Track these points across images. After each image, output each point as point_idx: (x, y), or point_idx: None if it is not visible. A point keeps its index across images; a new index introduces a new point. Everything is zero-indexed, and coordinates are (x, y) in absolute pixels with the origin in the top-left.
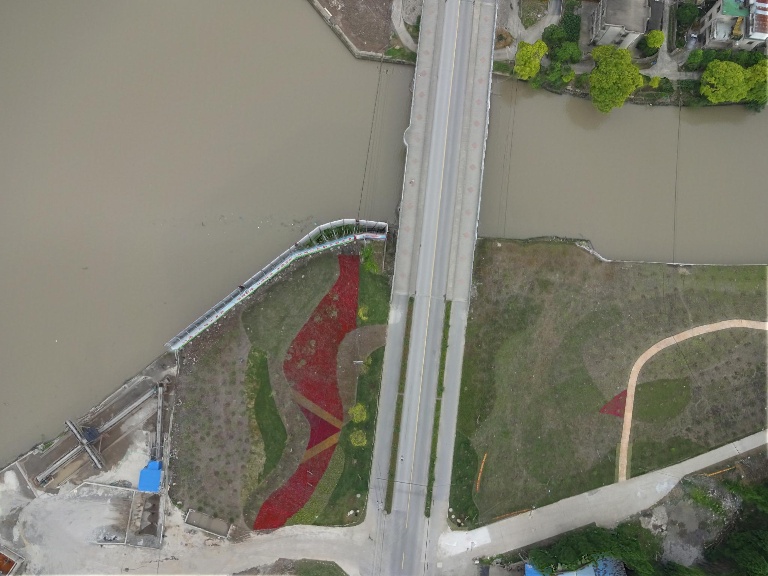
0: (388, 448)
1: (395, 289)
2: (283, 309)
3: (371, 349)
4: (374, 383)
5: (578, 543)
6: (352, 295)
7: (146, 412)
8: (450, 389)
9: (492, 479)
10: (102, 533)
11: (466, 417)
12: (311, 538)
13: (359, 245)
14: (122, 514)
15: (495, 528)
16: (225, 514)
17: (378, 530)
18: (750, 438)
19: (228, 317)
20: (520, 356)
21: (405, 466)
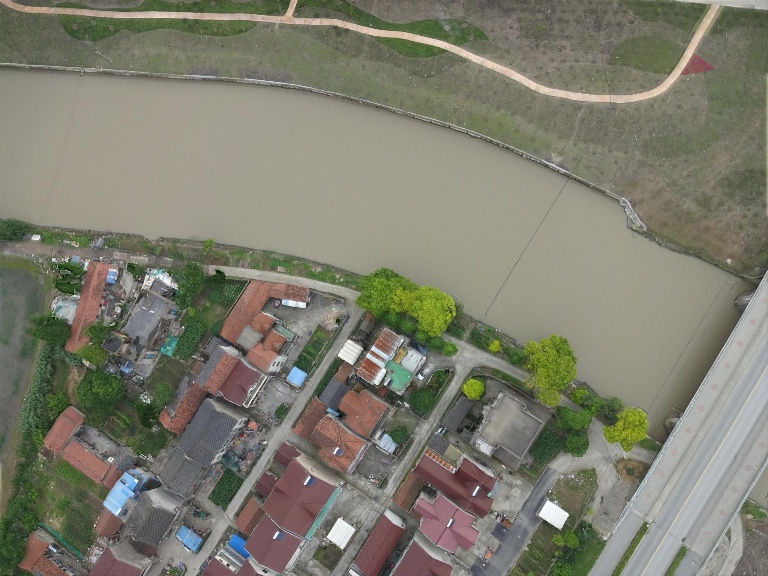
0: None
1: None
2: None
3: None
4: None
5: None
6: None
7: None
8: None
9: None
10: None
11: None
12: None
13: None
14: None
15: None
16: None
17: None
18: None
19: None
20: (764, 148)
21: None
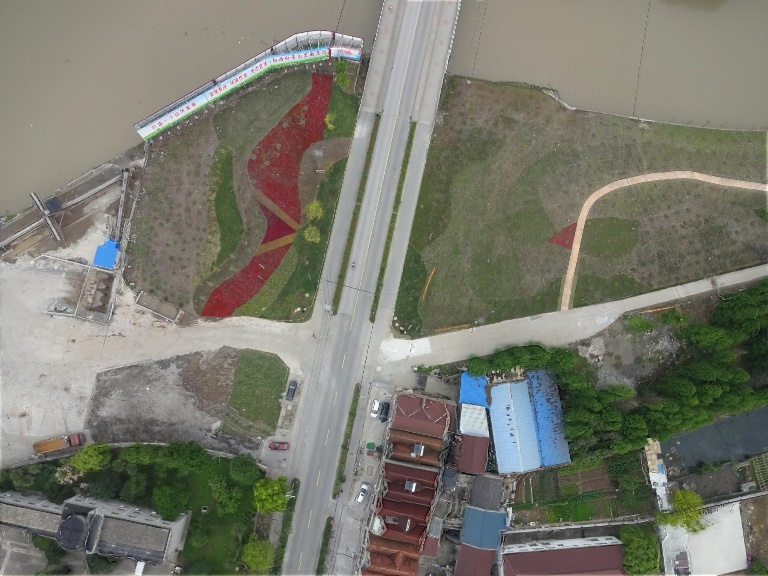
0: (341, 254)
1: (363, 106)
2: (253, 113)
3: (334, 160)
4: (334, 191)
5: (513, 348)
6: (322, 109)
7: (110, 197)
8: (407, 205)
9: (438, 294)
10: (53, 304)
11: (419, 233)
12: (257, 330)
13: (334, 67)
14: (75, 288)
15: (436, 340)
16: (175, 299)
17: (323, 329)
18: (692, 284)
19: (200, 118)
20: (478, 183)
21: (355, 272)
